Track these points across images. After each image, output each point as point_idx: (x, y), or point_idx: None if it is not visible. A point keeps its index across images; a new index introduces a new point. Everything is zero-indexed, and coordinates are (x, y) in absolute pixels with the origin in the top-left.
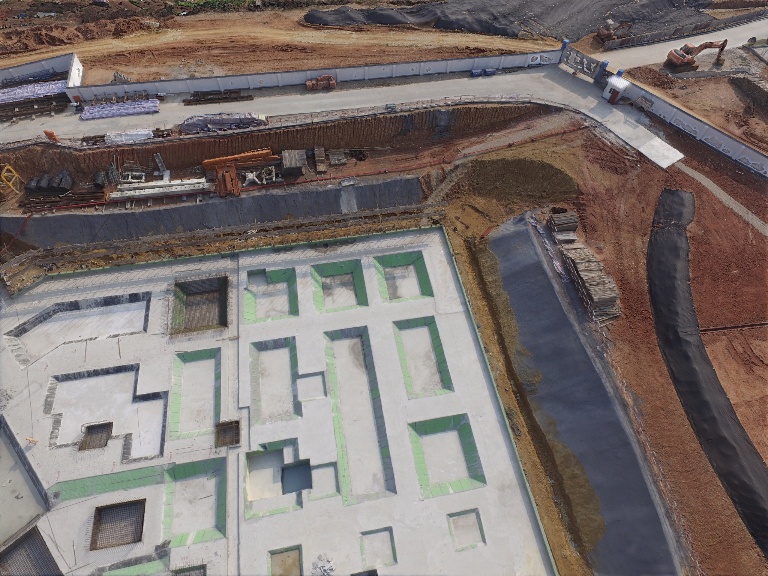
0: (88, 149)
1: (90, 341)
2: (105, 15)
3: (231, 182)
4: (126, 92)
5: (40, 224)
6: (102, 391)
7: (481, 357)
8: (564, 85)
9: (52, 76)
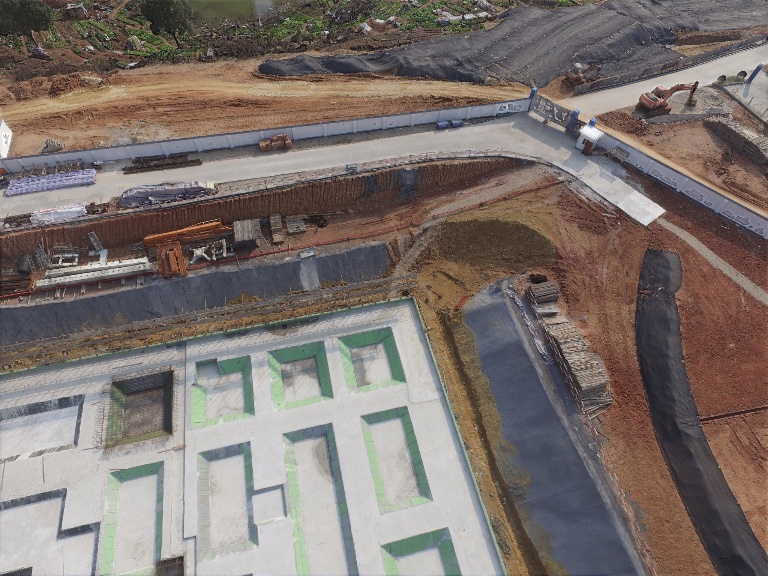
0: (11, 231)
1: (9, 463)
2: (42, 71)
3: (176, 261)
4: (58, 162)
5: None
6: (21, 526)
7: (461, 454)
8: (535, 135)
9: None
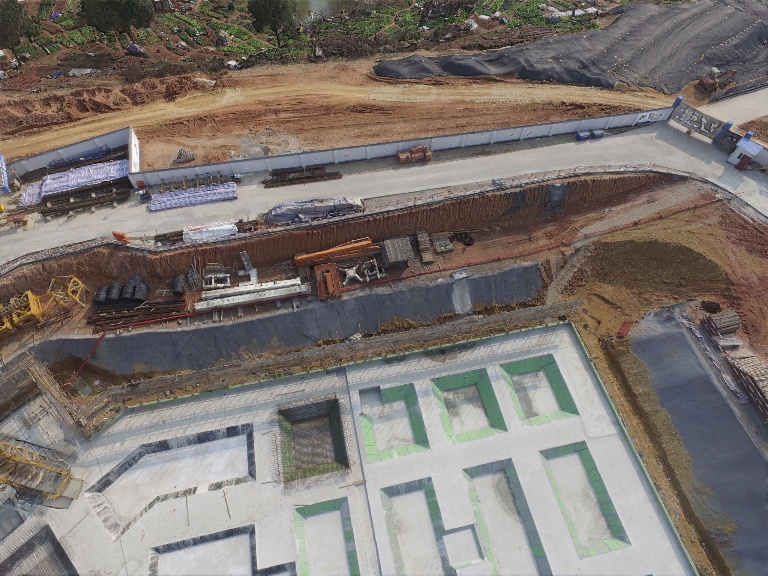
0: (164, 251)
1: (190, 496)
2: (150, 72)
3: (332, 283)
4: (197, 175)
5: (114, 345)
6: (214, 564)
7: (651, 495)
8: (682, 148)
9: (106, 154)
